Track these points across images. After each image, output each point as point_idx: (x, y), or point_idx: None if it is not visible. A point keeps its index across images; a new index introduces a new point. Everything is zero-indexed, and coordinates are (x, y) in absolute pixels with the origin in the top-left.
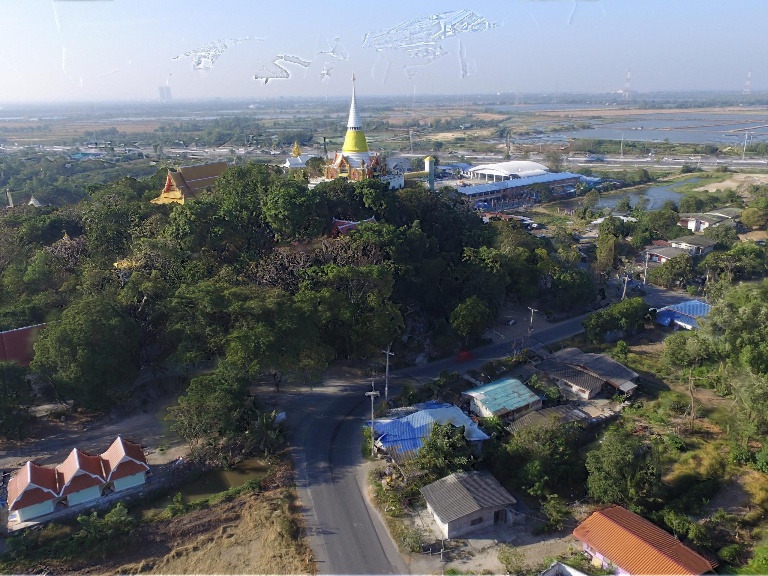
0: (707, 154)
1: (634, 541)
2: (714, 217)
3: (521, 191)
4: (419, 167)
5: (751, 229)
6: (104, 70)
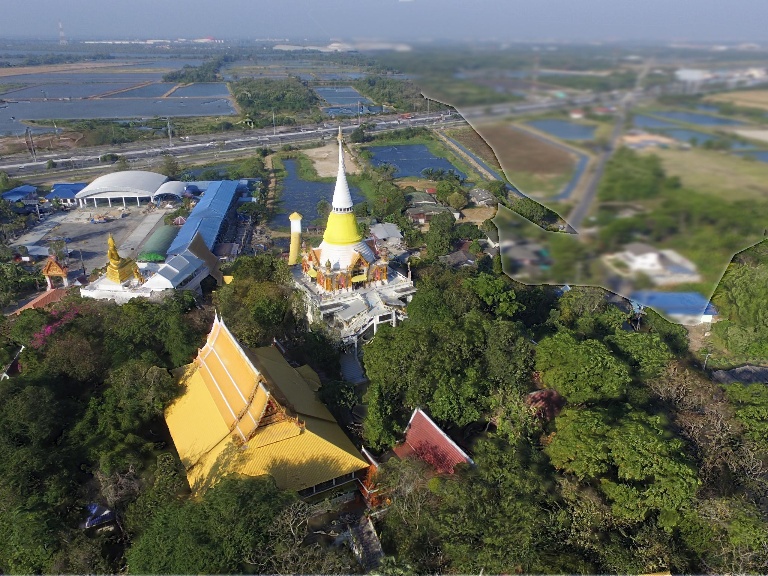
0: (236, 131)
1: None
2: None
3: (224, 216)
4: (7, 208)
5: (459, 210)
6: (532, 252)
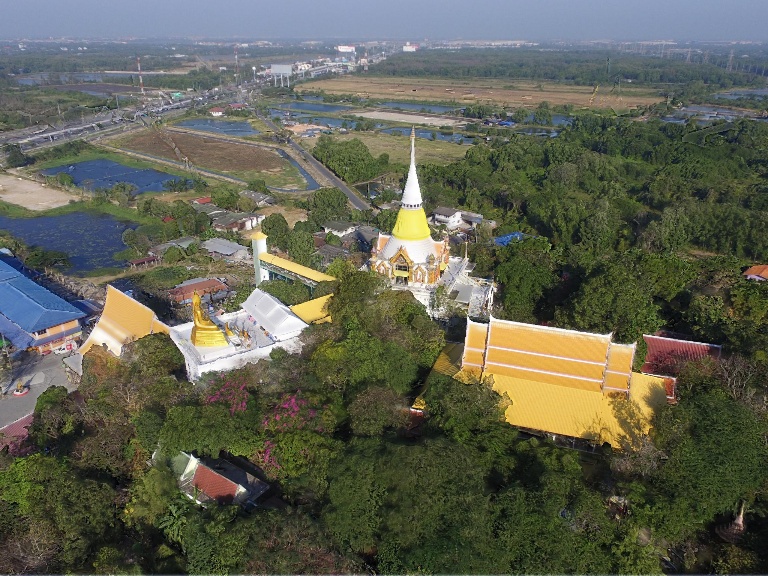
0: None
1: (767, 271)
2: (221, 215)
3: None
4: None
5: None
6: None
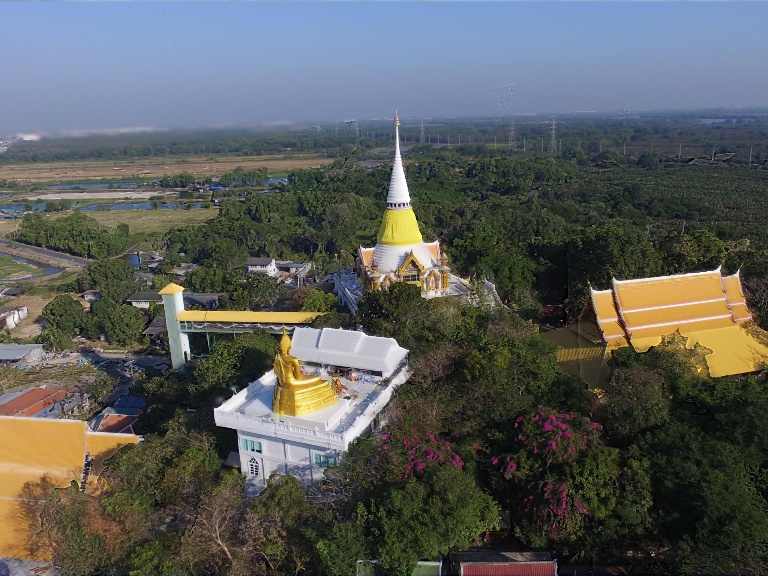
0: None
1: None
2: None
3: None
4: None
5: None
6: None
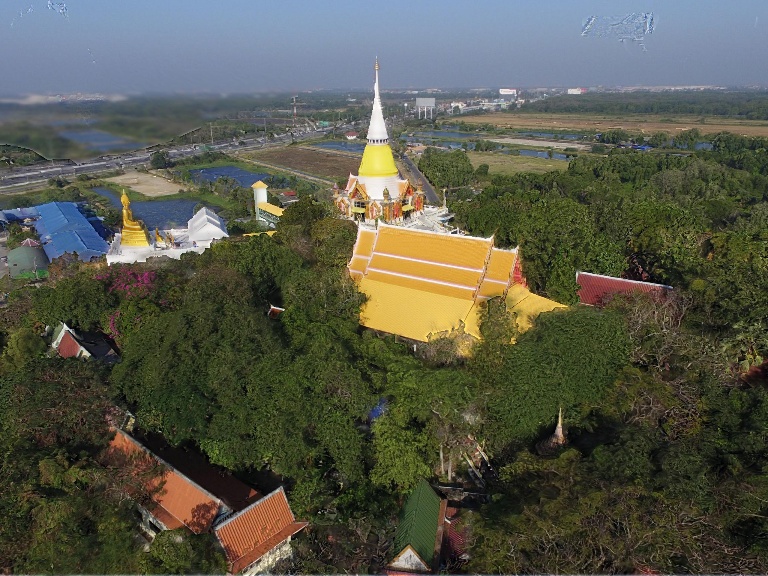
0: None
1: None
2: None
3: None
4: None
5: None
6: None
